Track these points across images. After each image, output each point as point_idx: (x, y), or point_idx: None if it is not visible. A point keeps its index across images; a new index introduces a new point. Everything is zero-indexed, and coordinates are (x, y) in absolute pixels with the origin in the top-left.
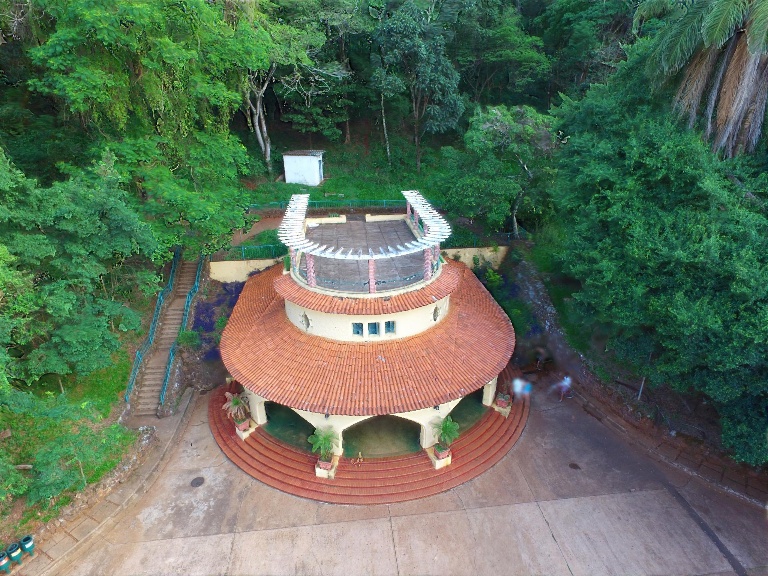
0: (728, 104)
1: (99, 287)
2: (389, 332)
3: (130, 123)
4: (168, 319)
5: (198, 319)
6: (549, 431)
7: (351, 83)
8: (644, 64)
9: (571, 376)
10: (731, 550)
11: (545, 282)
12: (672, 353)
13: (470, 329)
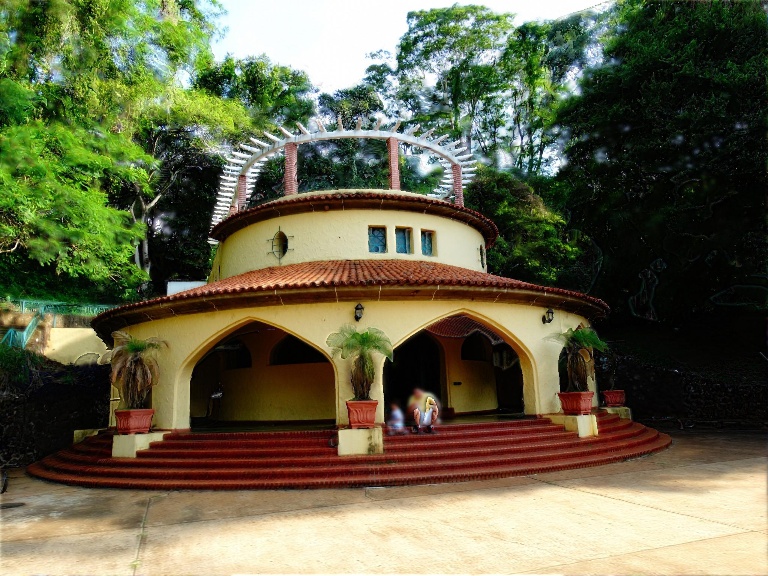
0: None
1: None
2: (425, 255)
3: None
4: None
5: None
6: (704, 435)
7: None
8: None
9: (671, 413)
10: None
11: None
12: None
13: None
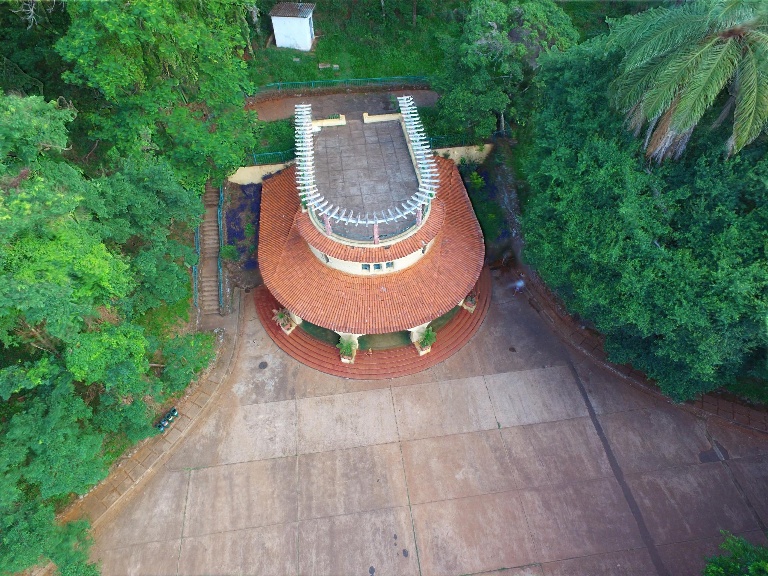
0: (656, 144)
1: None
2: (389, 267)
3: None
4: (206, 230)
5: (230, 229)
6: (501, 322)
7: None
8: (616, 60)
9: (526, 274)
10: (592, 404)
11: (519, 189)
12: None
13: (450, 255)
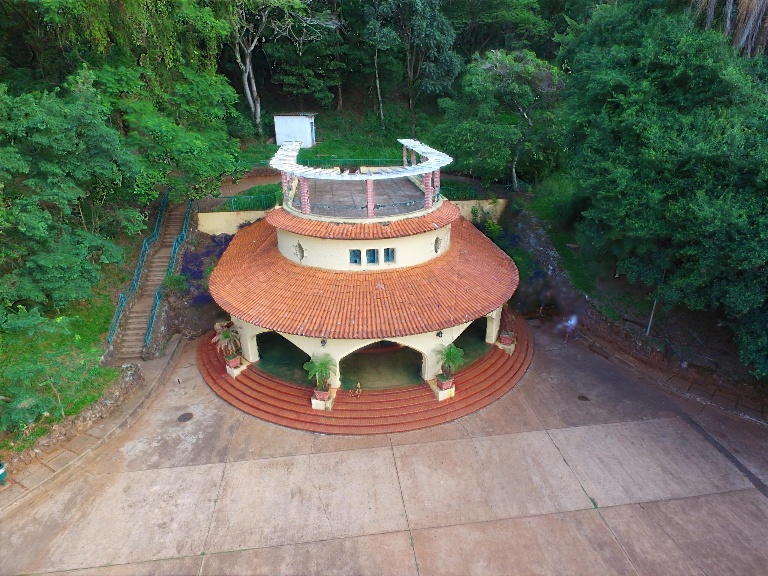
0: None
1: (79, 223)
2: (388, 261)
3: (111, 55)
4: (154, 266)
5: (186, 267)
6: (555, 368)
7: (343, 44)
8: None
9: (575, 319)
10: (751, 470)
11: (546, 230)
12: (689, 264)
13: (472, 263)
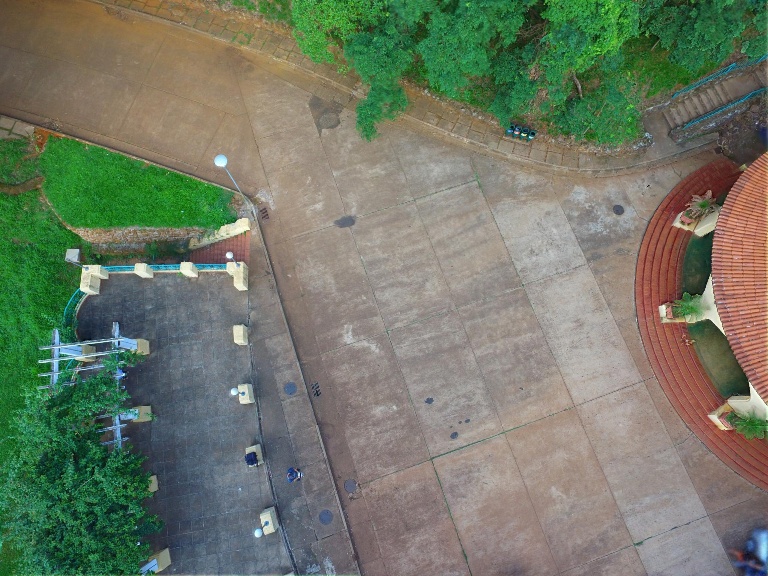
0: None
1: None
2: None
3: None
4: None
5: None
6: None
7: None
8: None
9: None
10: None
11: None
12: None
13: None
